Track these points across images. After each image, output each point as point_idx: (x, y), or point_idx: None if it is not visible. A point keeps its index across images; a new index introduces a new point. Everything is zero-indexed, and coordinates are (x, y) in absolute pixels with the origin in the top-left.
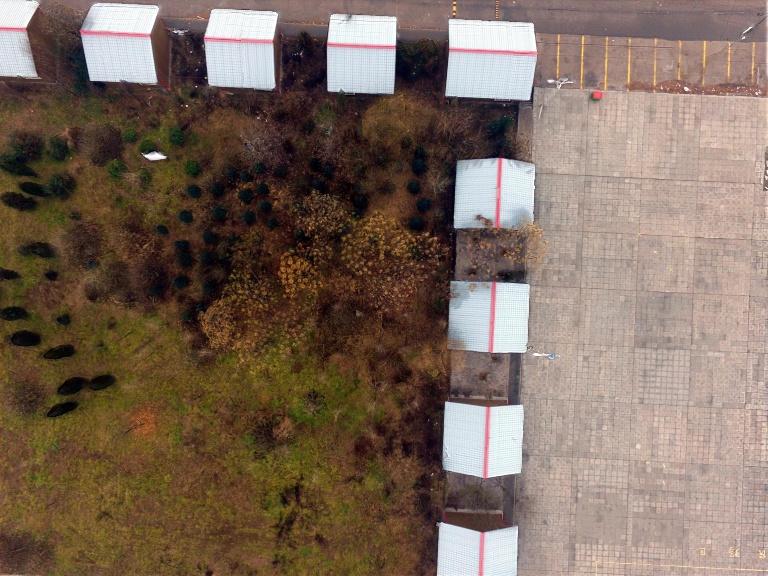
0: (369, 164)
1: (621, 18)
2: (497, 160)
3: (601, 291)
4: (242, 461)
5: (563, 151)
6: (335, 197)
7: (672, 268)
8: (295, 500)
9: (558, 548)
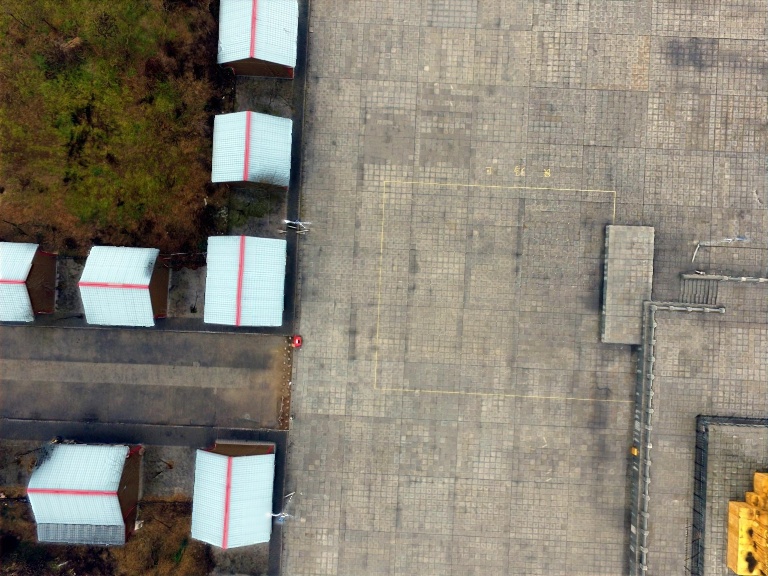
0: None
1: None
2: None
3: None
4: (33, 81)
5: None
6: None
7: None
8: (86, 120)
9: (346, 168)
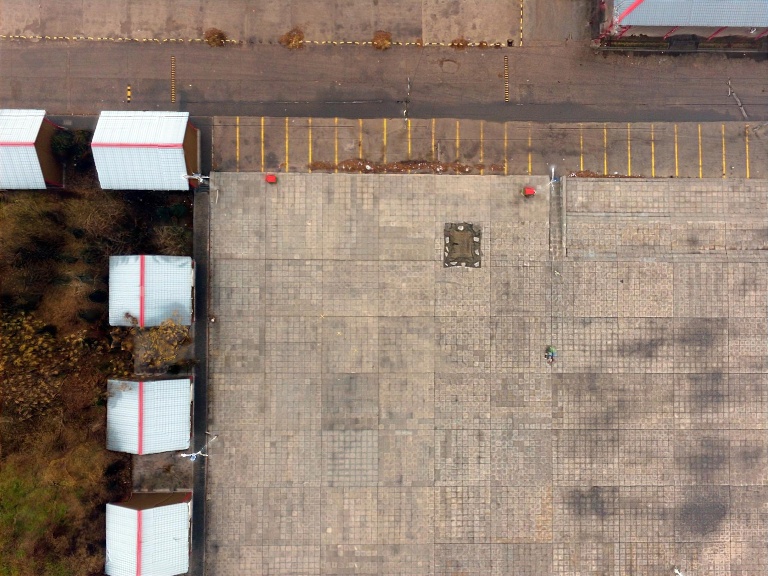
0: (39, 257)
1: (300, 98)
2: (139, 257)
3: (286, 375)
4: None
5: (242, 235)
6: None
7: (356, 348)
8: None
9: None
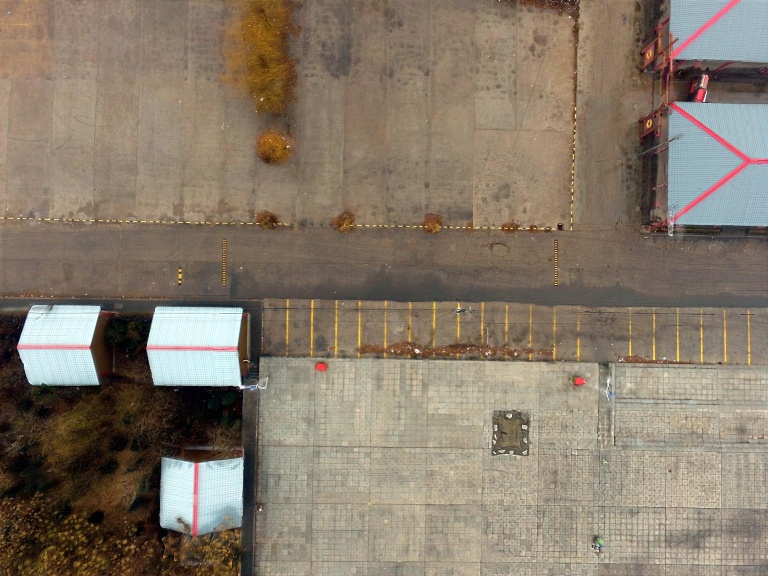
0: None
1: (350, 281)
2: (193, 465)
3: (332, 564)
4: None
5: (290, 422)
6: (37, 497)
7: (403, 537)
8: None
9: None
